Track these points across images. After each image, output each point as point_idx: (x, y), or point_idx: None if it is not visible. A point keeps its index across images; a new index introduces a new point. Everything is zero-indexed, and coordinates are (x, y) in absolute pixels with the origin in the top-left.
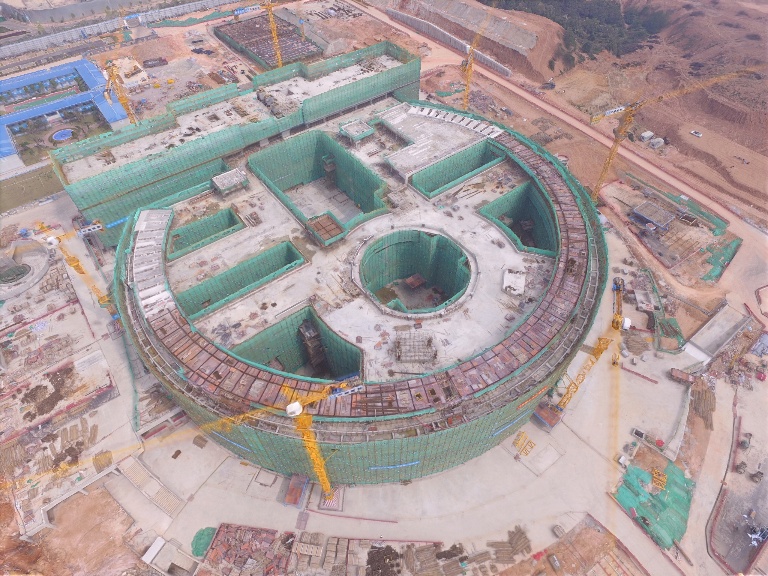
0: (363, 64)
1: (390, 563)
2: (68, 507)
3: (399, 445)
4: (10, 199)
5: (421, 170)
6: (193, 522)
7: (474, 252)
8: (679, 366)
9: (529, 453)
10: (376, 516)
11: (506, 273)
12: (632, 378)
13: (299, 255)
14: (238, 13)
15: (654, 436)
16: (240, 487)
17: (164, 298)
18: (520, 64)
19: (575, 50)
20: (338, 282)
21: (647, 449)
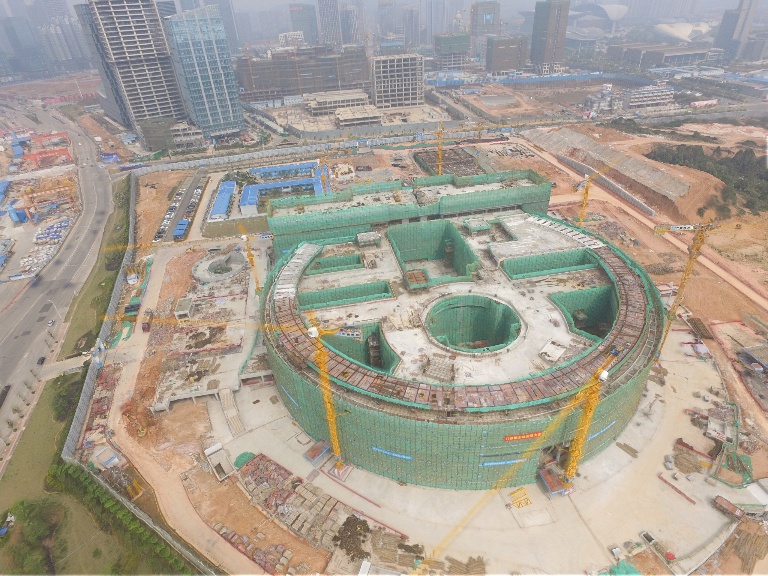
0: (505, 183)
1: (360, 532)
2: (182, 406)
3: (393, 424)
4: (241, 229)
5: (513, 258)
6: (244, 445)
7: (529, 323)
8: (732, 499)
9: (522, 507)
10: (367, 496)
11: (548, 343)
12: (667, 489)
13: (390, 291)
14: (416, 136)
15: (666, 547)
16: (284, 437)
17: (290, 291)
18: (667, 208)
19: (734, 204)
20: (409, 315)
21: (653, 556)
